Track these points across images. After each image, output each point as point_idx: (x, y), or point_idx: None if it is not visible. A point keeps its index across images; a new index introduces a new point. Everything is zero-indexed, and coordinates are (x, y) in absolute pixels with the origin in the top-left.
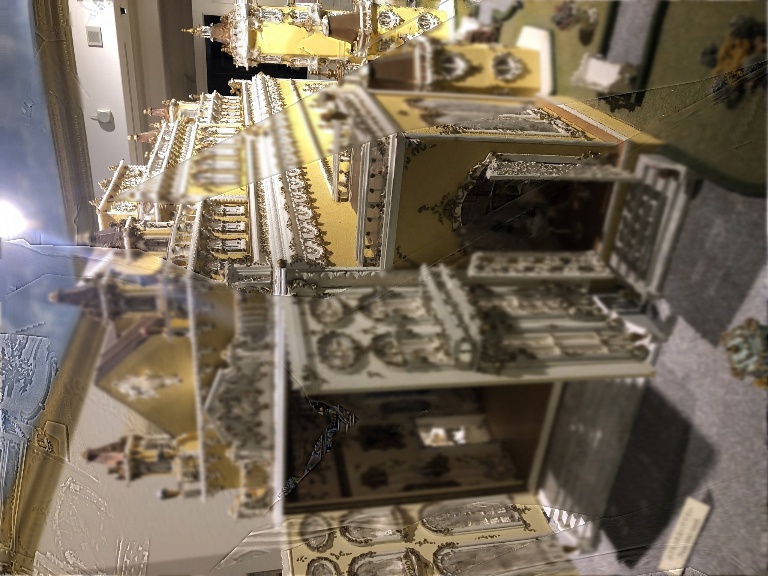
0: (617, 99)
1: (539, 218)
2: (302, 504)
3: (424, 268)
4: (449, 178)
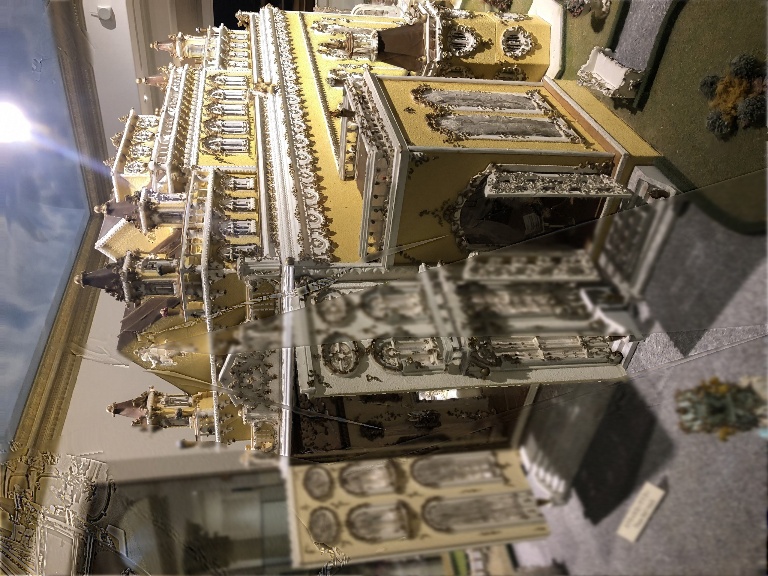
0: (621, 99)
1: (495, 432)
2: None
3: (405, 453)
4: (450, 185)
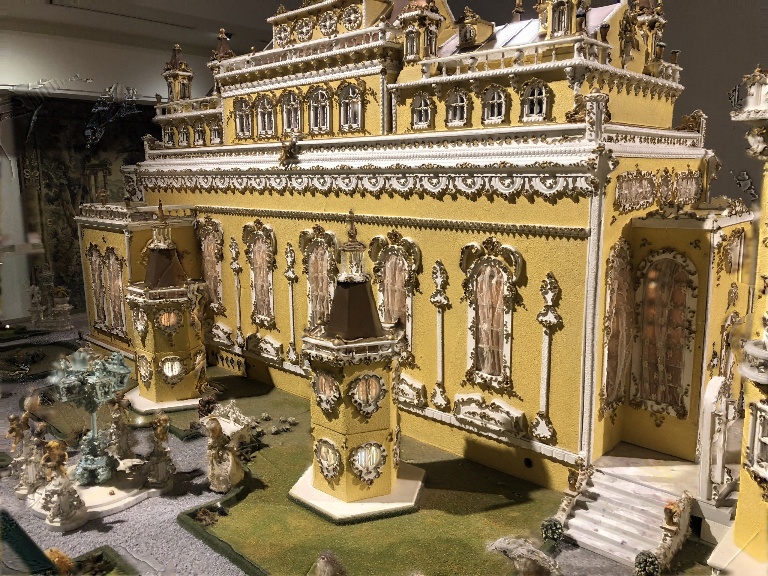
0: None
1: None
2: None
3: None
4: None
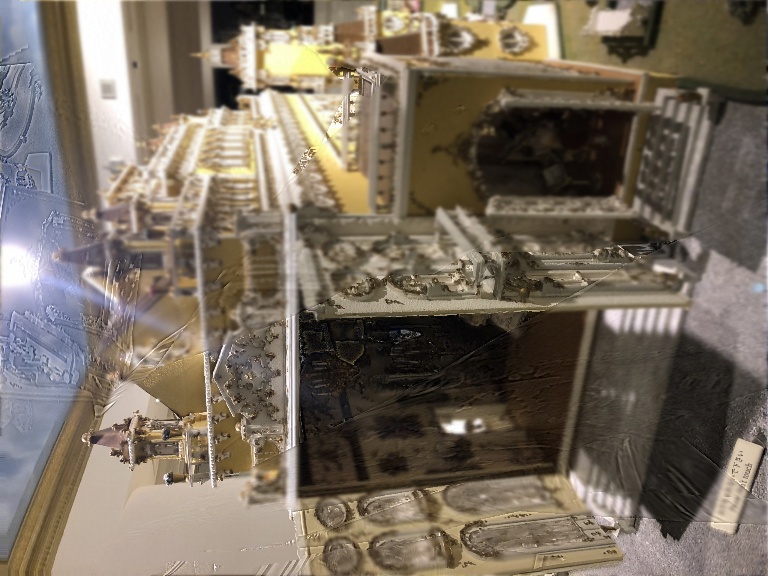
0: None
1: None
2: (321, 220)
3: None
4: None
